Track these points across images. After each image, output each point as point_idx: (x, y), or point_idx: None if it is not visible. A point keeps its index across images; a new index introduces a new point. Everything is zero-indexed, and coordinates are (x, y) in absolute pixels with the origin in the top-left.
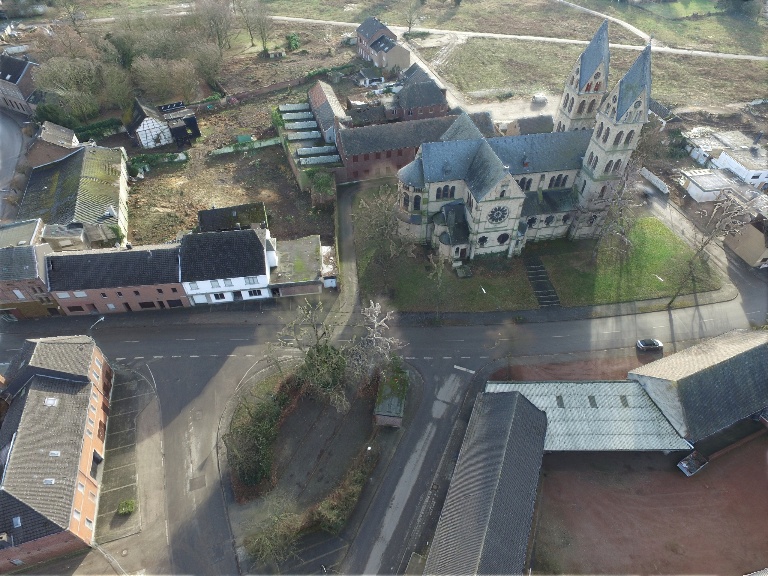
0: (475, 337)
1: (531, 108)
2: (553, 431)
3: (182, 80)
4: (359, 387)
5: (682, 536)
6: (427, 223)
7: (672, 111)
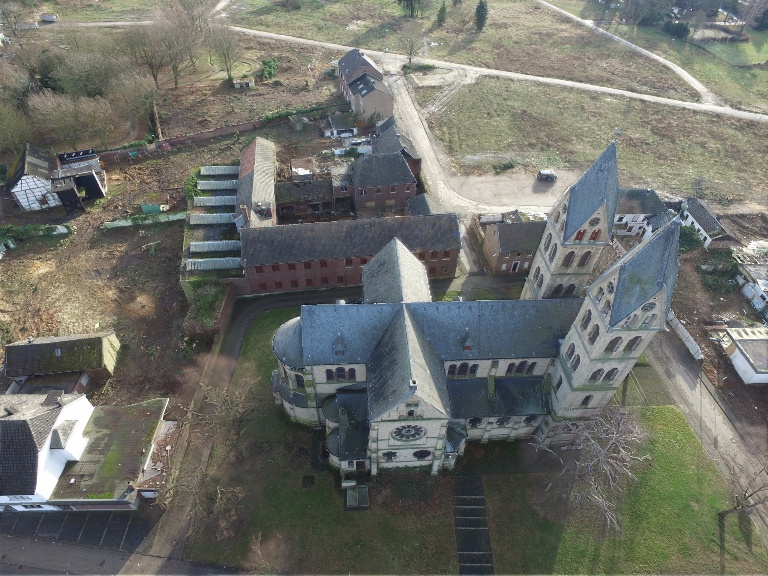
0: None
1: (533, 188)
2: None
3: (91, 123)
4: None
5: None
6: (317, 407)
7: (724, 209)
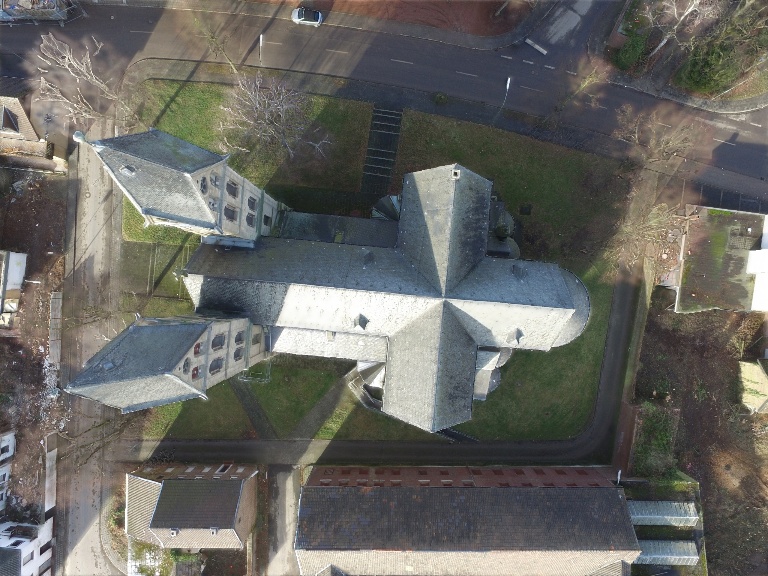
0: None
1: None
2: None
3: None
4: (660, 55)
5: None
6: None
7: None
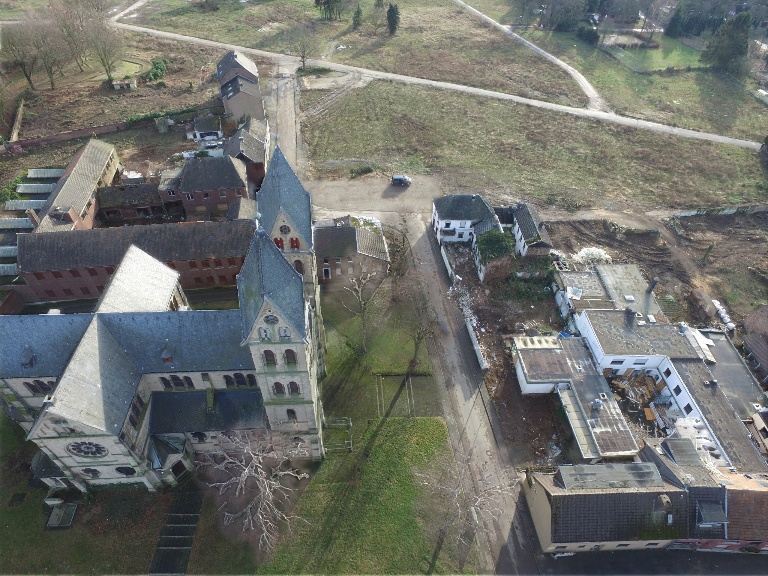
0: None
1: (383, 193)
2: None
3: None
4: None
5: None
6: None
7: (568, 216)
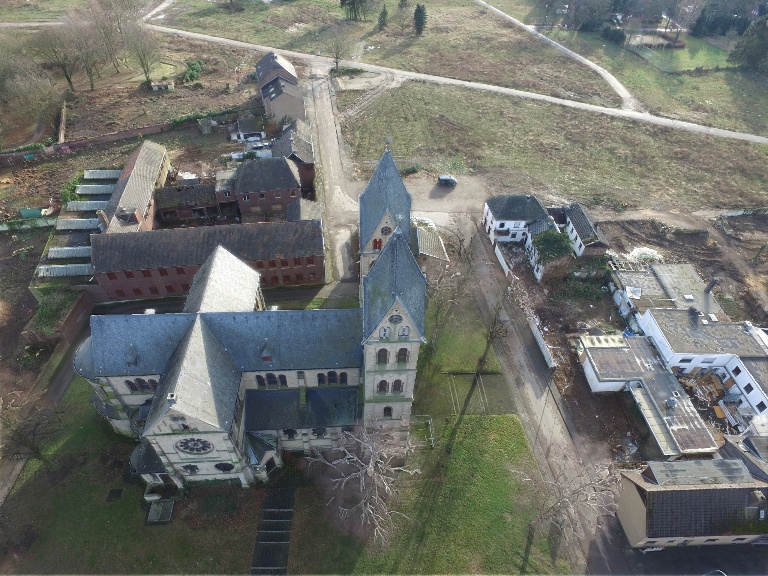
0: None
1: (431, 193)
2: None
3: None
4: None
5: None
6: (129, 418)
7: (616, 216)
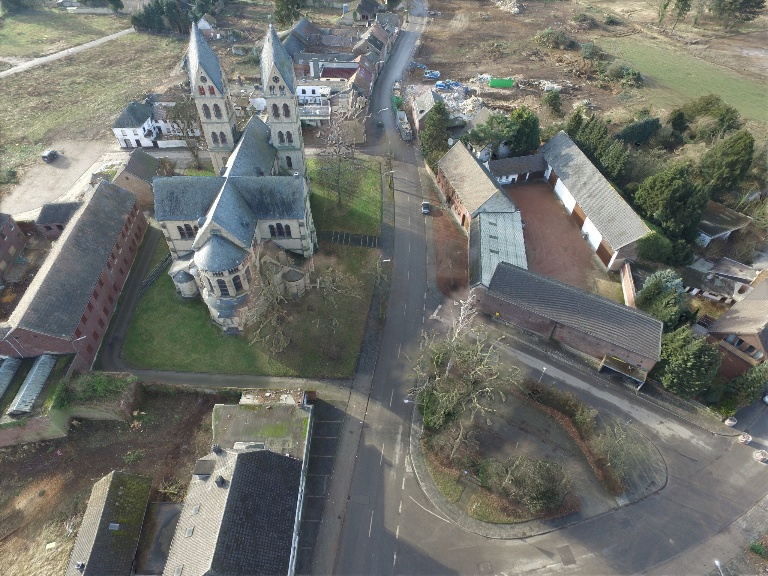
0: (403, 296)
1: (60, 167)
2: (515, 263)
3: None
4: None
5: (558, 243)
6: None
7: None
